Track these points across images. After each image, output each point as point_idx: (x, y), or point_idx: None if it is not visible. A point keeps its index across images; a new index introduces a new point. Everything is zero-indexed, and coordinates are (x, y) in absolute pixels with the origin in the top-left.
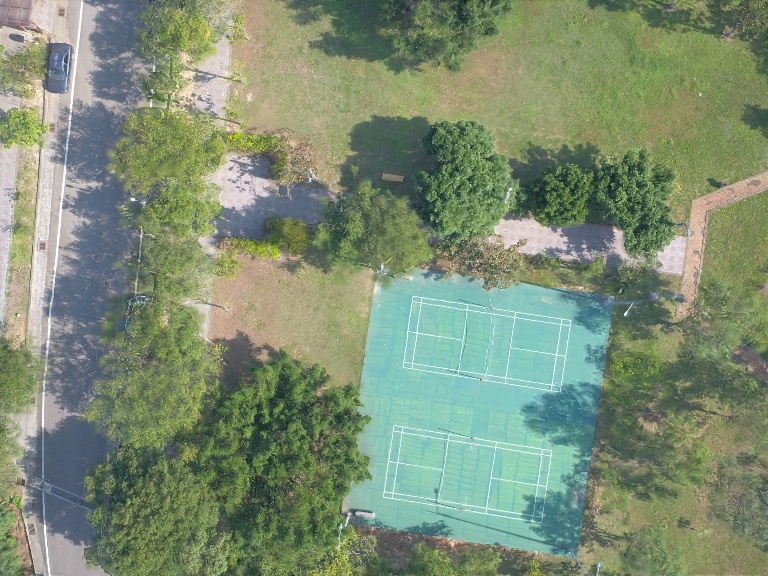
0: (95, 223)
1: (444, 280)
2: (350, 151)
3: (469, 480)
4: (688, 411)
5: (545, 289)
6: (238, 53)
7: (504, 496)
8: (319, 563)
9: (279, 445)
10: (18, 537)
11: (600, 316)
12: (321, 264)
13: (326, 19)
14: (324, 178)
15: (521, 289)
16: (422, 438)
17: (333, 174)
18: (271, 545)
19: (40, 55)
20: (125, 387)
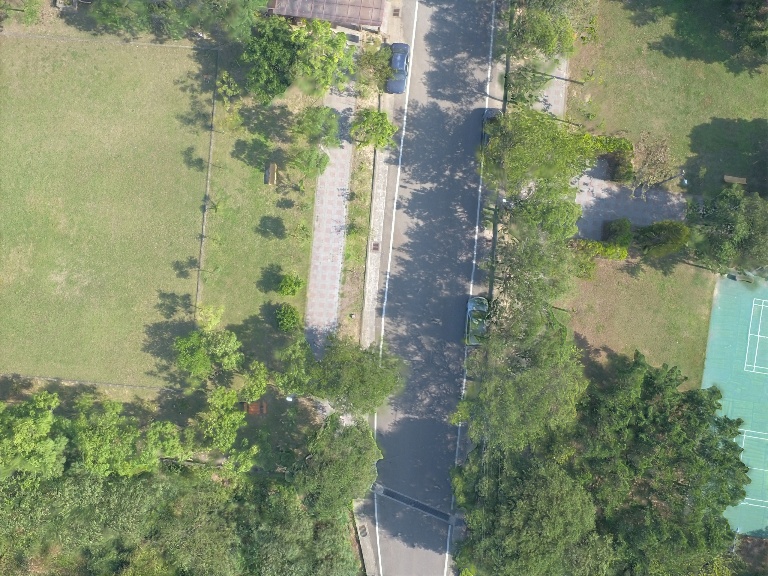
0: (429, 224)
1: None
2: (690, 153)
3: None
4: None
5: None
6: (576, 54)
7: None
8: None
9: (663, 448)
10: (348, 539)
11: None
12: (661, 266)
13: (665, 20)
14: None
15: None
16: (765, 441)
17: None
18: (664, 548)
19: (386, 55)
20: (504, 389)
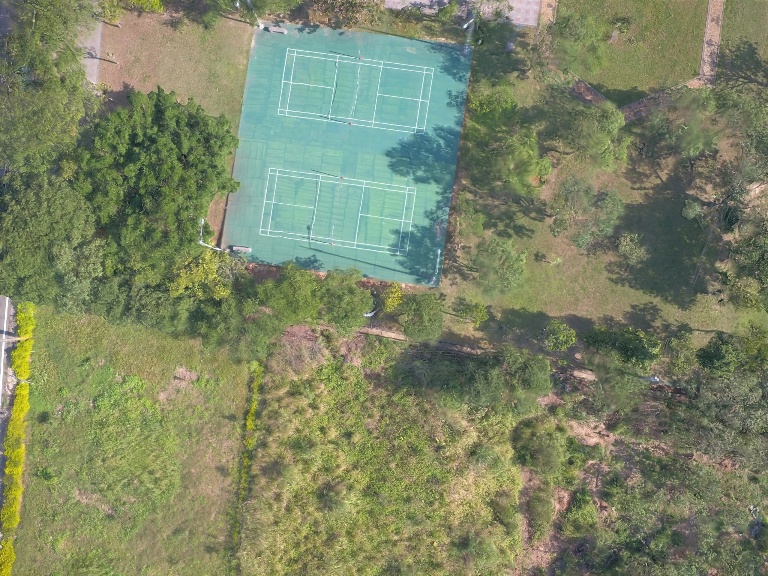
0: None
1: (311, 23)
2: None
3: (339, 217)
4: (543, 152)
5: (410, 40)
6: None
7: (372, 231)
8: (187, 266)
9: (149, 156)
10: None
11: (461, 64)
12: (202, 20)
13: None
14: None
15: (387, 41)
16: (296, 179)
17: None
18: (139, 242)
19: None
20: (7, 106)
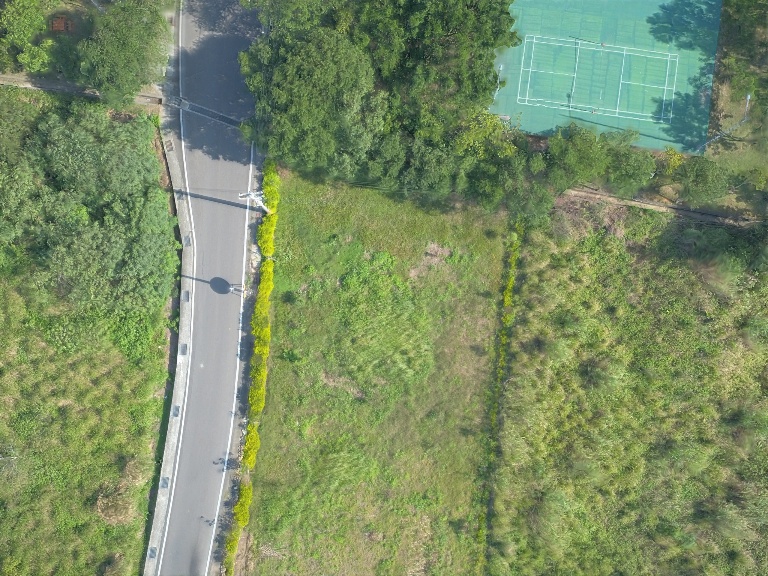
0: None
1: None
2: None
3: (600, 84)
4: None
5: None
6: None
7: (634, 98)
8: (474, 119)
9: (434, 4)
10: (155, 156)
11: None
12: None
13: None
14: None
15: None
16: (554, 46)
17: None
18: (432, 90)
19: None
20: None
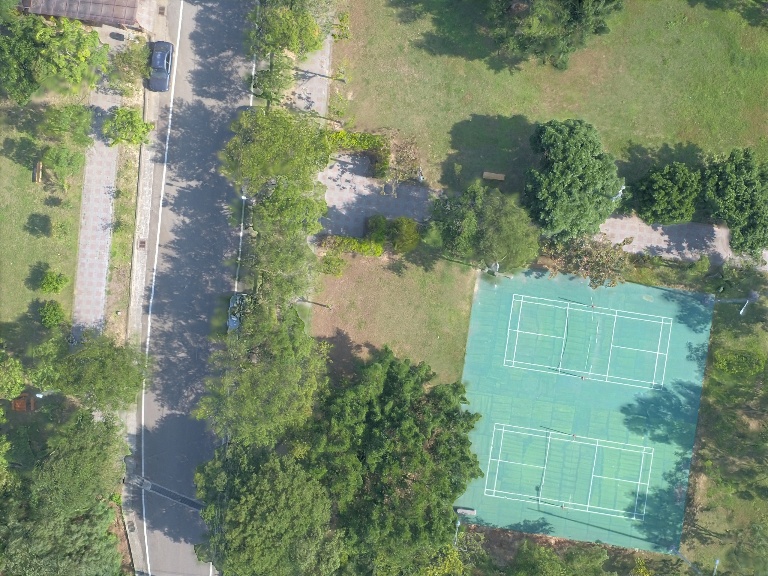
0: (195, 221)
1: (549, 278)
2: (451, 149)
3: (571, 478)
4: None
5: (646, 287)
6: (338, 52)
7: (606, 494)
8: (432, 560)
9: (393, 442)
10: (117, 534)
11: (701, 314)
12: (422, 262)
13: (426, 18)
14: (425, 176)
15: (622, 287)
16: (523, 436)
17: (434, 172)
18: (388, 542)
19: (143, 54)
20: (238, 384)
